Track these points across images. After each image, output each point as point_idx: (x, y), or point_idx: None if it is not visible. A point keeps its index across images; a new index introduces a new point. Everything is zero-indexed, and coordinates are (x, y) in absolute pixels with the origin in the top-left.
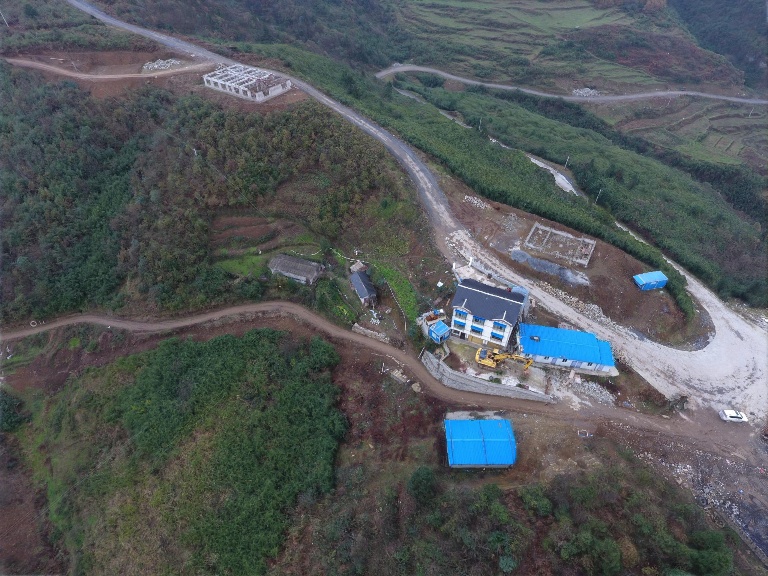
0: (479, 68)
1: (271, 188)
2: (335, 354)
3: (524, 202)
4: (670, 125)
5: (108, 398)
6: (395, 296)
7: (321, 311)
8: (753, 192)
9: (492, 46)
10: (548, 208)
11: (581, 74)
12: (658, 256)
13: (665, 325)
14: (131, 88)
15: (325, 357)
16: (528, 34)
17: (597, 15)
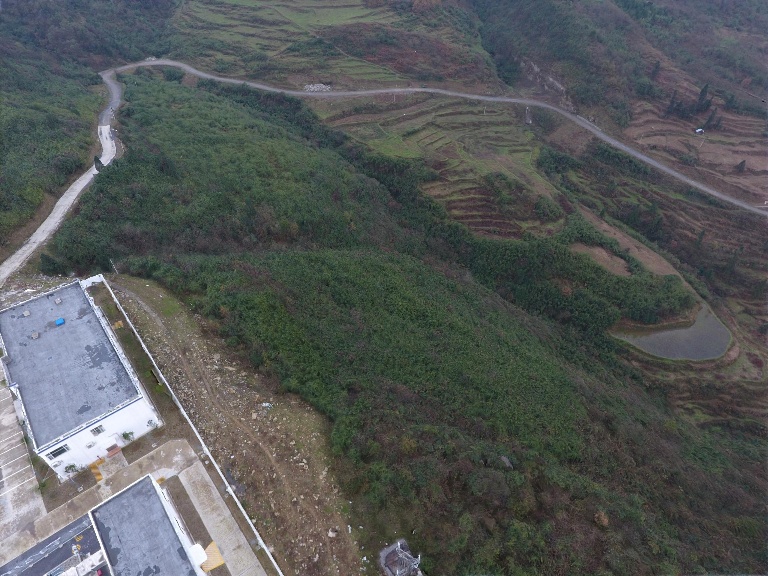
0: (219, 63)
1: None
2: None
3: None
4: (385, 120)
5: None
6: None
7: None
8: (413, 184)
9: (244, 42)
10: None
11: (320, 70)
12: None
13: None
14: None
15: None
16: (286, 31)
17: (362, 13)
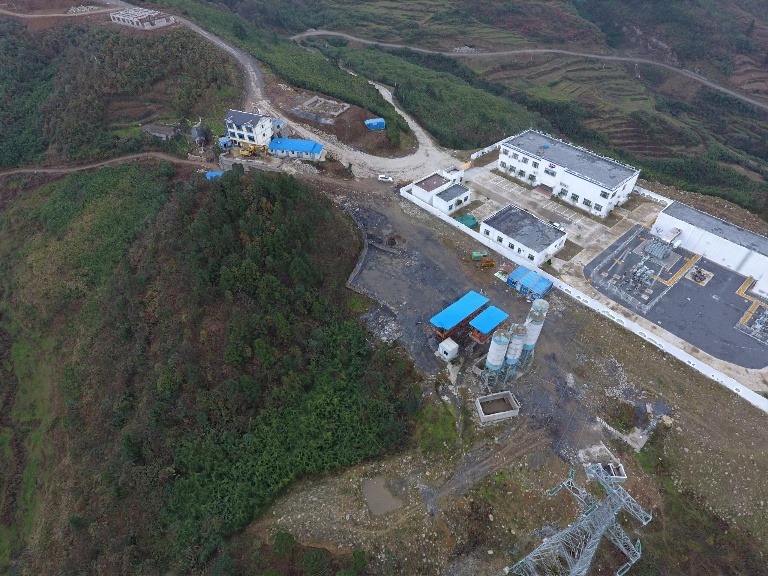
0: (377, 31)
1: (148, 82)
2: (172, 168)
3: (316, 87)
4: (529, 74)
5: (32, 209)
6: (214, 136)
7: (173, 153)
8: (576, 120)
9: (391, 14)
10: (330, 89)
11: (463, 35)
12: (399, 118)
13: (373, 144)
14: (57, 23)
15: (164, 169)
16: (424, 4)
17: None
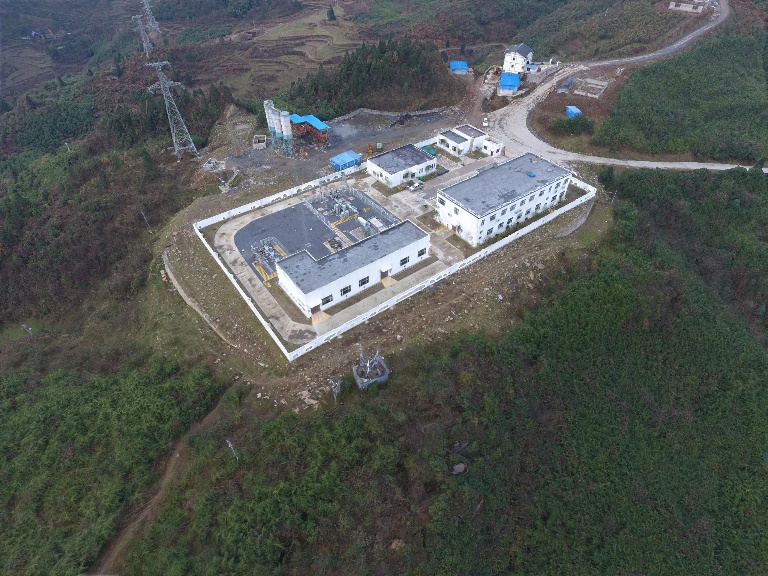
0: None
1: (599, 35)
2: None
3: None
4: None
5: None
6: None
7: None
8: None
9: None
10: None
11: None
12: None
13: None
14: None
15: None
16: None
17: None
